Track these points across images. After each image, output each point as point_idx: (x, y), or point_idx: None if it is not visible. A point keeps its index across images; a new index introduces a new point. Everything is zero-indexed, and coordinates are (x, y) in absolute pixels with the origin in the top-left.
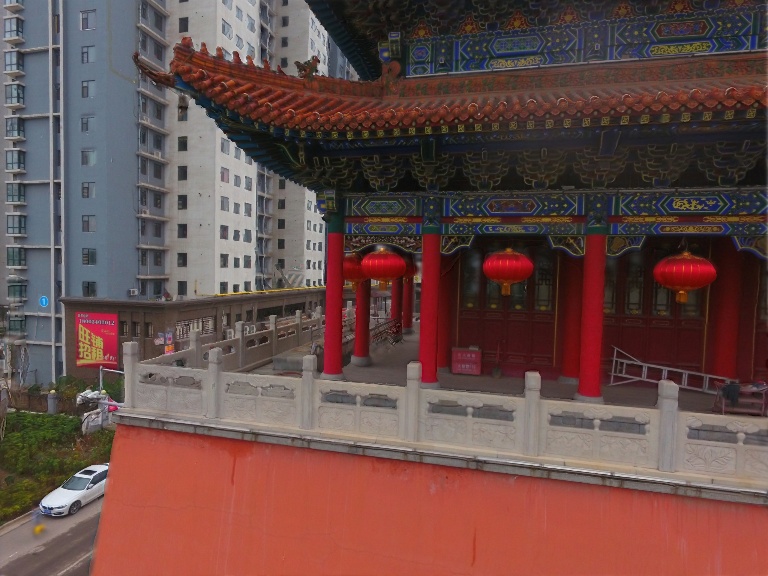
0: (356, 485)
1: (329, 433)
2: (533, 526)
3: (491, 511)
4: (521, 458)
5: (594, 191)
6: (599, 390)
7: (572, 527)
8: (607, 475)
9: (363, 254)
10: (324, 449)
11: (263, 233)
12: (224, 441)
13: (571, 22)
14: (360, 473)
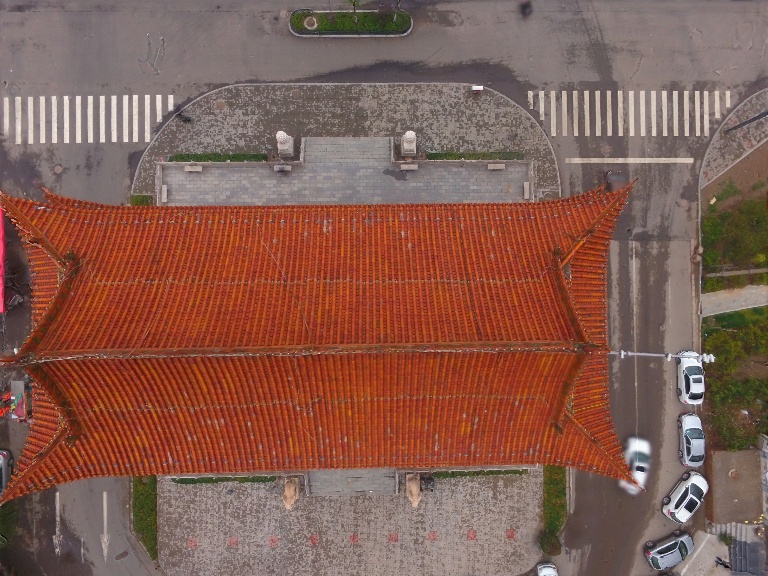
0: None
1: None
2: None
3: None
4: None
5: None
6: None
7: None
8: None
9: None
10: None
11: None
12: None
13: None
14: None
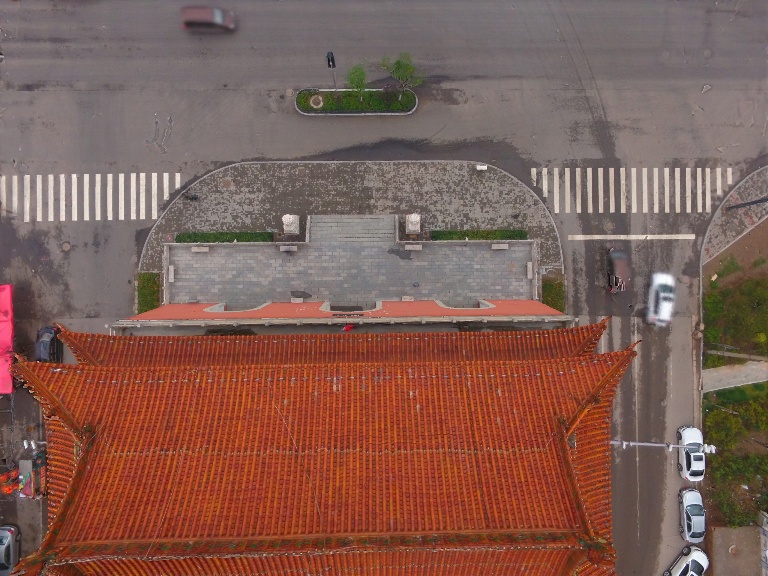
0: None
1: (503, 317)
2: None
3: None
4: (453, 317)
5: None
6: None
7: None
8: None
9: None
10: None
11: None
12: None
13: None
14: None
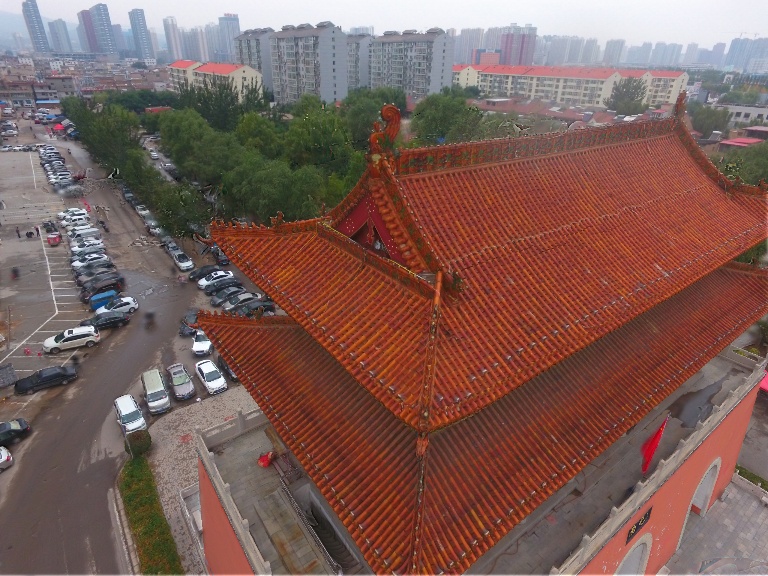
0: None
1: None
2: None
3: None
4: None
5: None
6: None
7: None
8: None
9: None
10: None
11: None
12: None
13: None
14: None
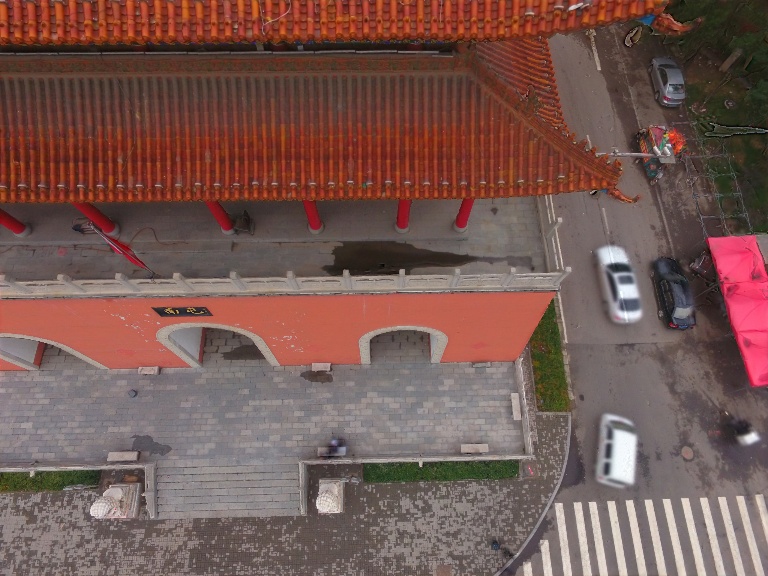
0: None
1: None
2: None
3: None
4: None
5: None
6: (25, 223)
7: None
8: None
9: None
10: None
11: None
12: None
13: None
14: None
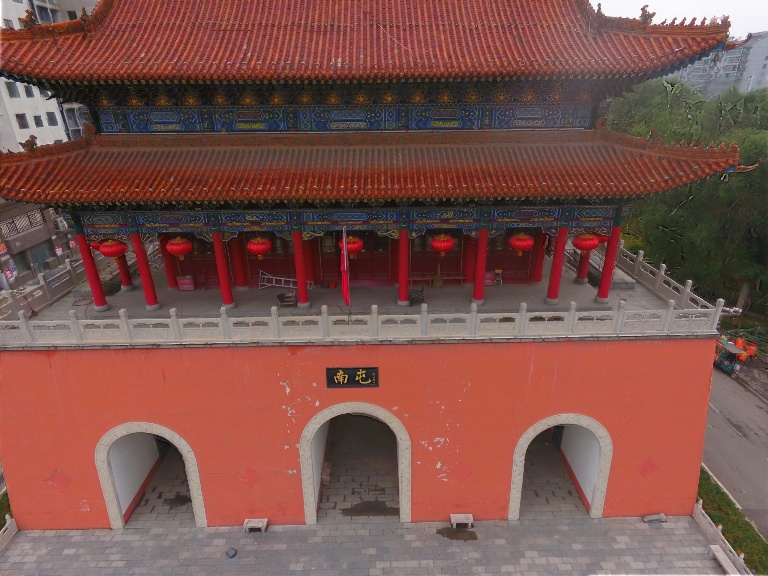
0: (109, 361)
1: (91, 342)
2: (184, 364)
3: (167, 362)
4: (174, 342)
5: (209, 212)
6: None
7: (198, 363)
8: (206, 343)
9: (100, 243)
10: (90, 349)
11: (72, 103)
12: (41, 351)
13: (193, 104)
14: (110, 356)
